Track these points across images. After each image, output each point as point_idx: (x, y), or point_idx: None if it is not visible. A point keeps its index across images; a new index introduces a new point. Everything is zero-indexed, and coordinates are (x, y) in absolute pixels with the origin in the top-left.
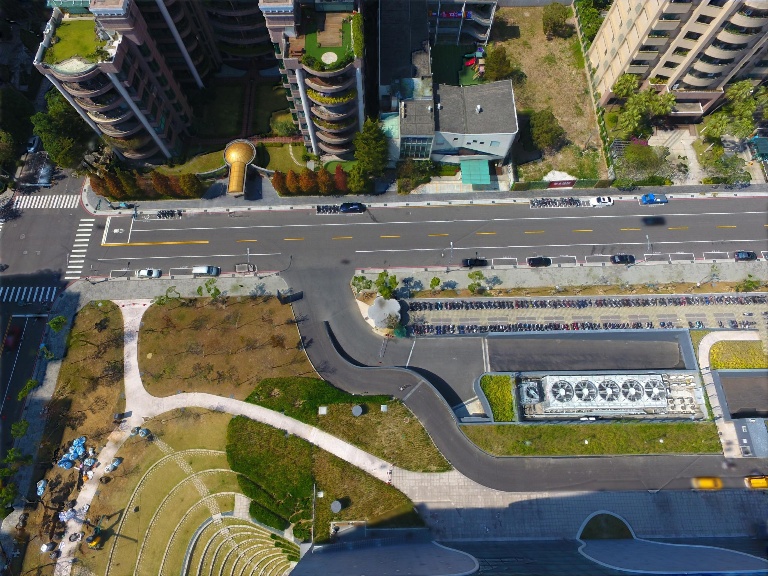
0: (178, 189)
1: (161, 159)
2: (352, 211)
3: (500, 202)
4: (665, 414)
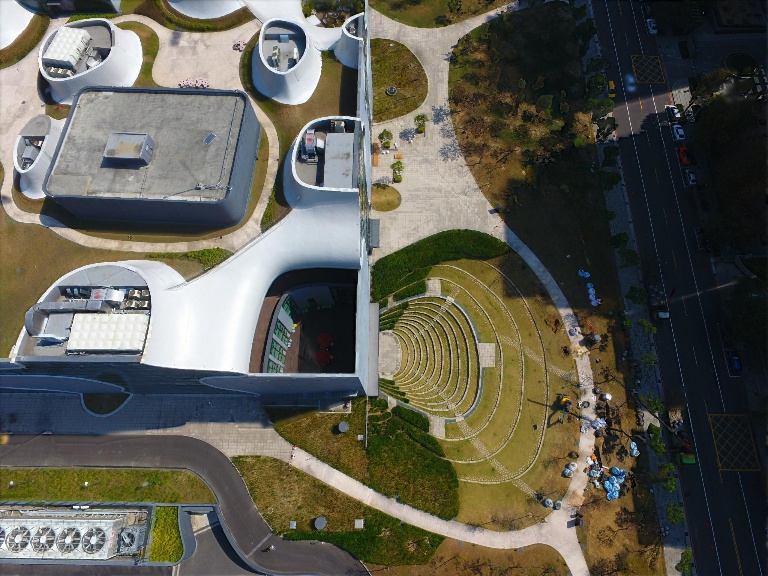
0: None
1: None
2: None
3: None
4: (0, 510)
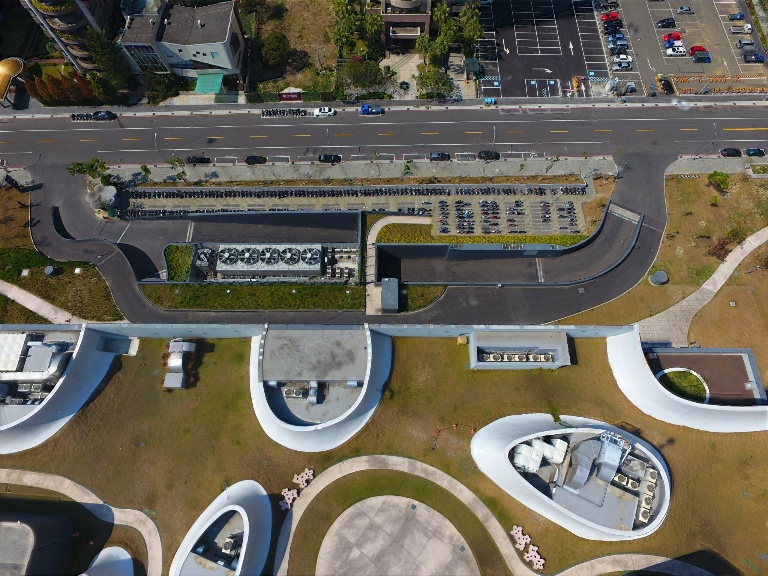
0: None
1: None
2: (102, 118)
3: (236, 112)
4: (323, 279)
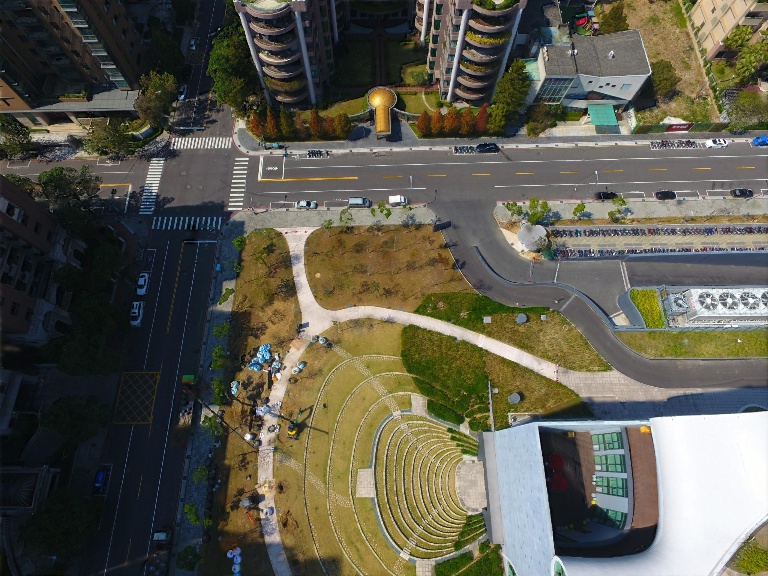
0: (331, 129)
1: (305, 105)
2: (488, 151)
3: (623, 144)
4: None
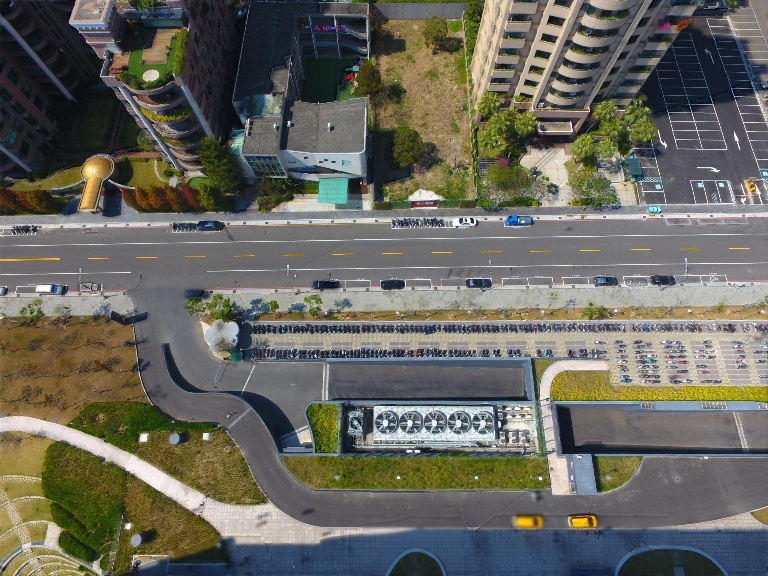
0: (28, 205)
1: (22, 173)
2: (208, 229)
3: (361, 222)
4: (496, 447)
